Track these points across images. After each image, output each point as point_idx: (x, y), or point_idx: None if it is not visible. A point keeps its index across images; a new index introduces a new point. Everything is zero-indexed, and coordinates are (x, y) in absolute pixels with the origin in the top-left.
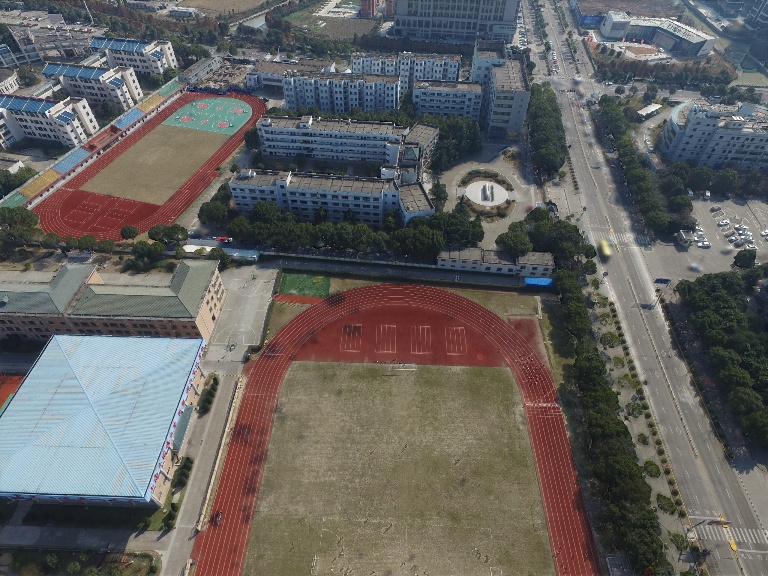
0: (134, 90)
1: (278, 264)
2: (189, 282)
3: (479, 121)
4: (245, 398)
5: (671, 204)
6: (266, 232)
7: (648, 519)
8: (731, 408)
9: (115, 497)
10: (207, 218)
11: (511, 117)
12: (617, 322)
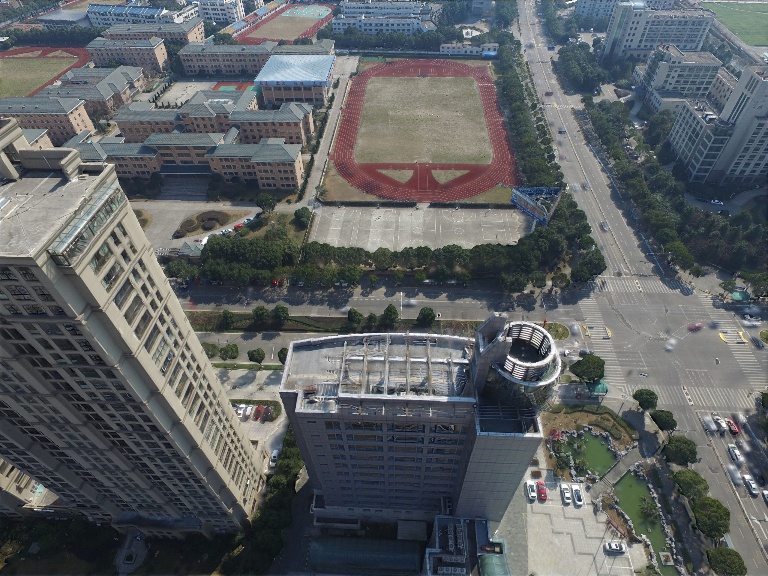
0: (260, 0)
1: (359, 55)
2: (324, 42)
3: (466, 4)
4: (352, 85)
5: (567, 29)
6: (353, 38)
7: (519, 89)
8: (571, 83)
9: (315, 80)
10: (322, 36)
11: (485, 0)
12: (527, 65)
